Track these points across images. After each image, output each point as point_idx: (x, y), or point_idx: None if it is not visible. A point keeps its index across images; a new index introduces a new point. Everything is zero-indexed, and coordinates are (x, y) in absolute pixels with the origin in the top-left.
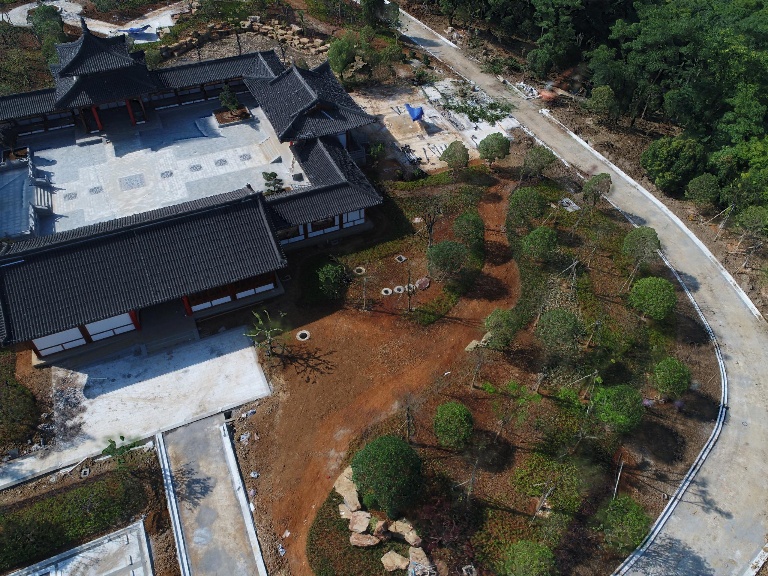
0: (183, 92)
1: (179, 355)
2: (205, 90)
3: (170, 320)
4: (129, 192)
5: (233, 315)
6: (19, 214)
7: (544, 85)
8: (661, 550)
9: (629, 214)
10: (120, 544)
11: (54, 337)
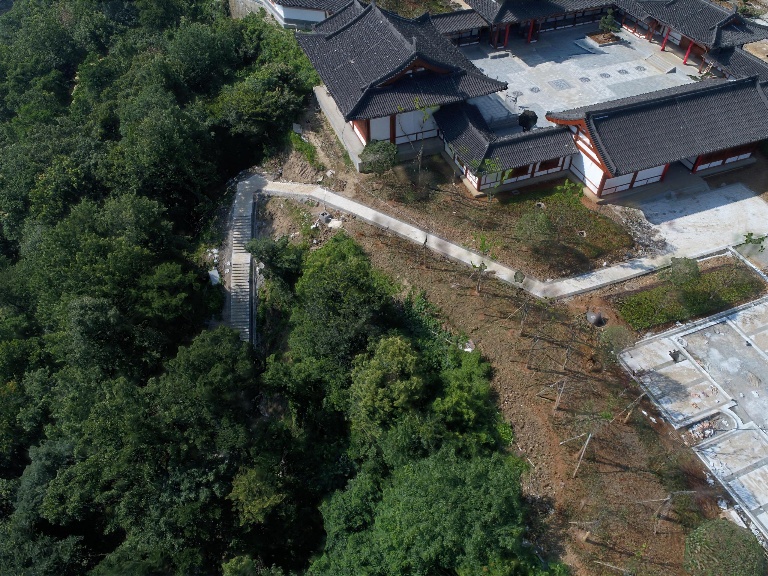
0: (551, 19)
1: (703, 200)
2: (567, 18)
3: (680, 176)
4: (564, 91)
5: (725, 175)
6: (494, 104)
7: None
8: None
9: None
10: (765, 307)
11: (618, 179)
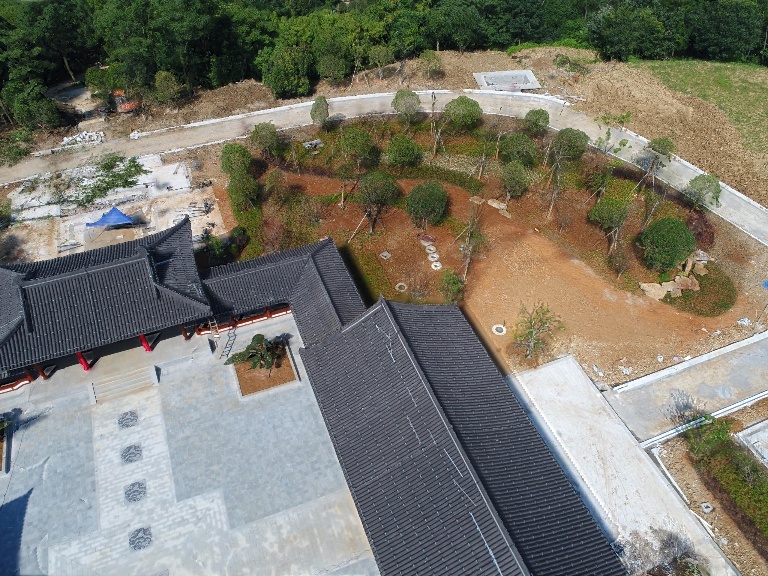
0: None
1: None
2: None
3: None
4: None
5: None
6: None
7: (70, 129)
8: (640, 163)
9: (329, 119)
10: (763, 448)
11: None
